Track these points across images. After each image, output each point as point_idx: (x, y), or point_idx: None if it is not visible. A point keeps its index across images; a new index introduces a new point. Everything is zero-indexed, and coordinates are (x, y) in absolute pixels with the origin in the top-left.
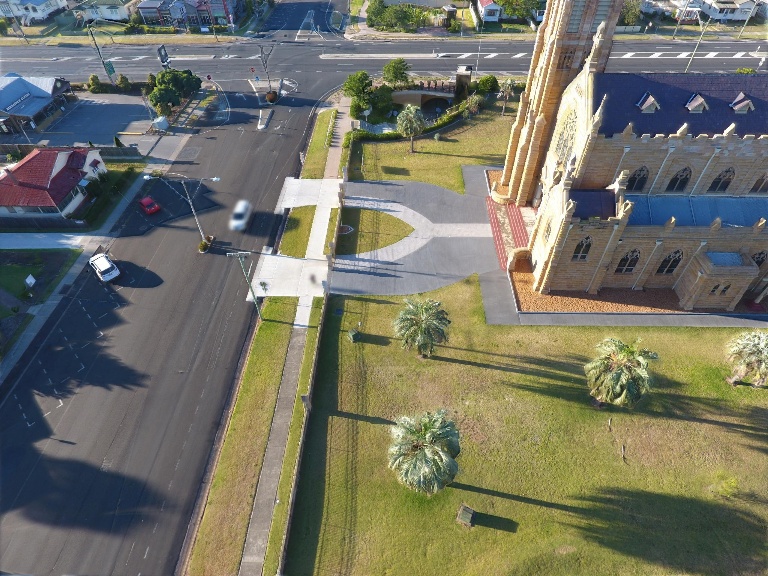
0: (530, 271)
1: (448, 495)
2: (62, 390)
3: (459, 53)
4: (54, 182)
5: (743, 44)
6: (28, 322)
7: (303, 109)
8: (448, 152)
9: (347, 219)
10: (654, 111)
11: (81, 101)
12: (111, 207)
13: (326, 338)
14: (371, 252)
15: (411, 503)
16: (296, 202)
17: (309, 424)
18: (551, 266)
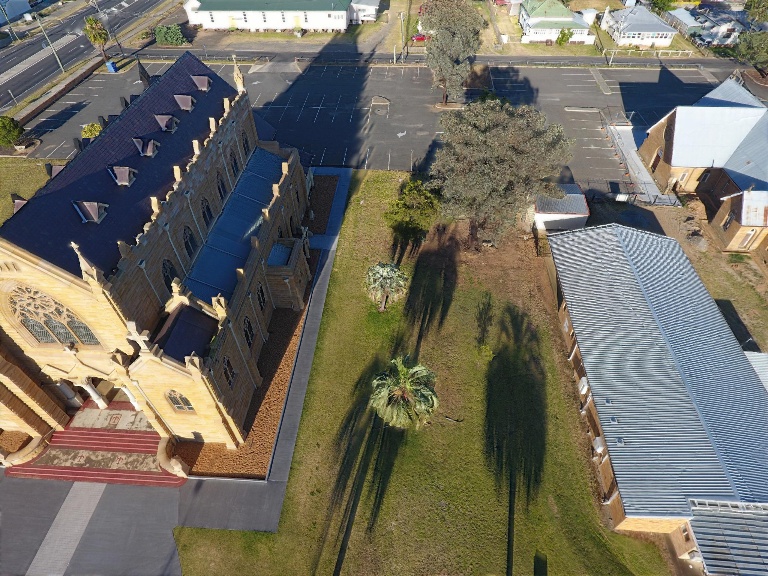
0: (199, 445)
1: None
2: None
3: None
4: None
5: None
6: None
7: None
8: None
9: None
10: (105, 212)
11: None
12: None
13: None
14: None
15: None
16: None
17: None
18: (231, 417)
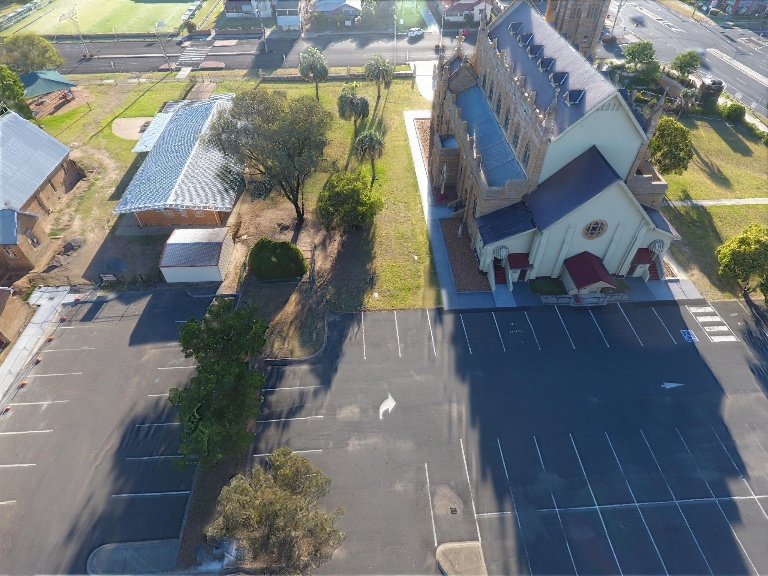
0: None
1: None
2: (354, 41)
3: None
4: (459, 5)
5: None
6: (384, 30)
7: (606, 54)
8: None
9: None
10: None
11: None
12: None
13: None
14: None
15: None
16: None
17: None
18: None
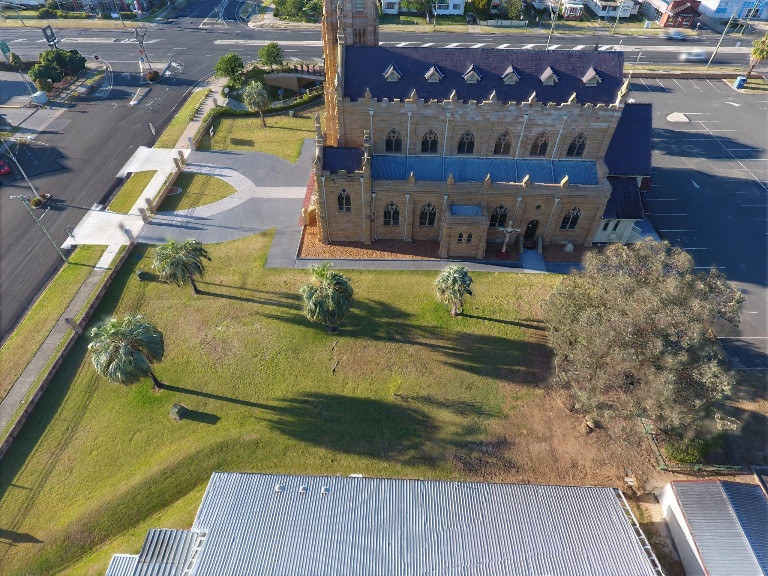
0: None
1: (170, 397)
2: None
3: None
4: None
5: (613, 39)
6: None
7: (180, 88)
8: (297, 127)
9: (180, 182)
10: (398, 80)
11: None
12: None
13: (118, 278)
14: (189, 209)
15: (136, 403)
16: (140, 167)
17: (75, 344)
18: (320, 217)
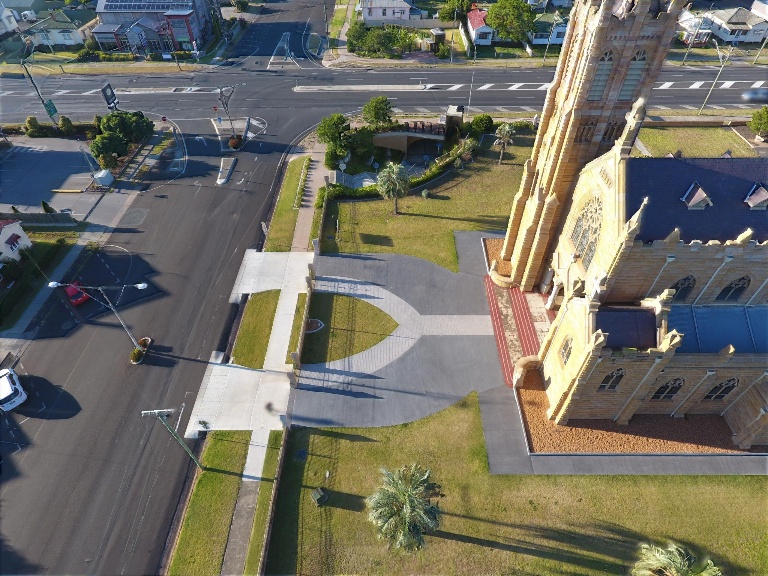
0: (542, 388)
1: None
2: None
3: (449, 84)
4: None
5: (760, 71)
6: None
7: (271, 156)
8: (438, 213)
9: (317, 310)
10: (704, 207)
11: (16, 148)
12: (31, 295)
13: (283, 499)
14: (345, 360)
15: None
16: (256, 285)
17: None
18: (572, 399)
